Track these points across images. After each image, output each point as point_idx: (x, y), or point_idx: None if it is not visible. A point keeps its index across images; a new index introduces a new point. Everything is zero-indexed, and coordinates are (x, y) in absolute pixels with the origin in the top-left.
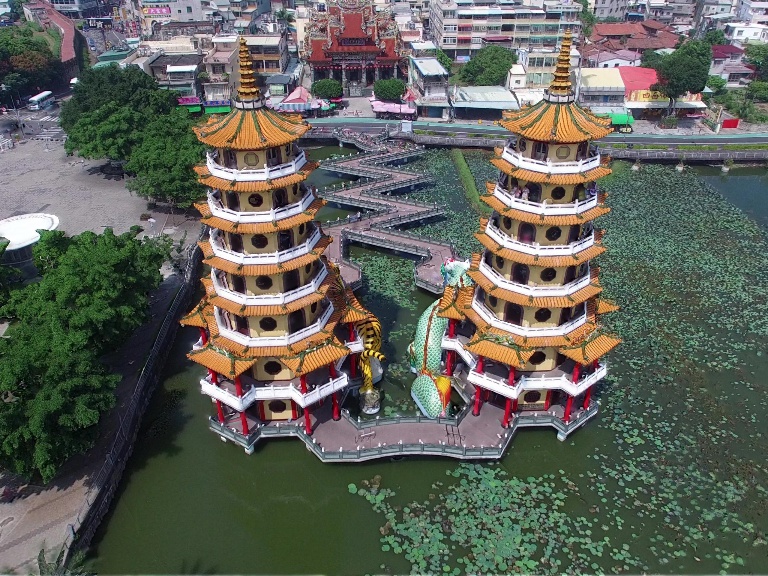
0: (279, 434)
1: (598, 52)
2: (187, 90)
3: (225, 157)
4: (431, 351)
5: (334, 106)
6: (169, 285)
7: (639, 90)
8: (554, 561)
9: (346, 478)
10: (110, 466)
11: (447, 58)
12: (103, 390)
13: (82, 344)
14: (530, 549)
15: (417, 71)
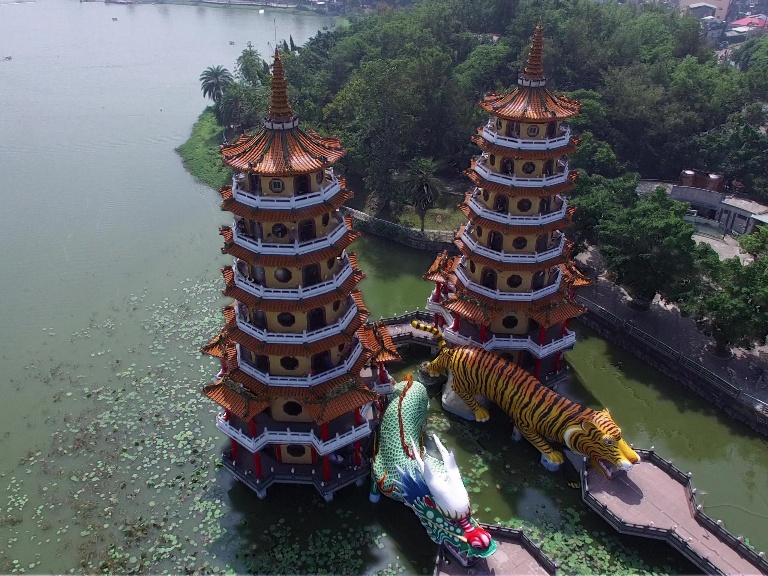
0: None
1: None
2: None
3: None
4: None
5: None
6: (764, 397)
7: None
8: None
9: None
10: None
11: None
12: None
13: None
14: None
15: None
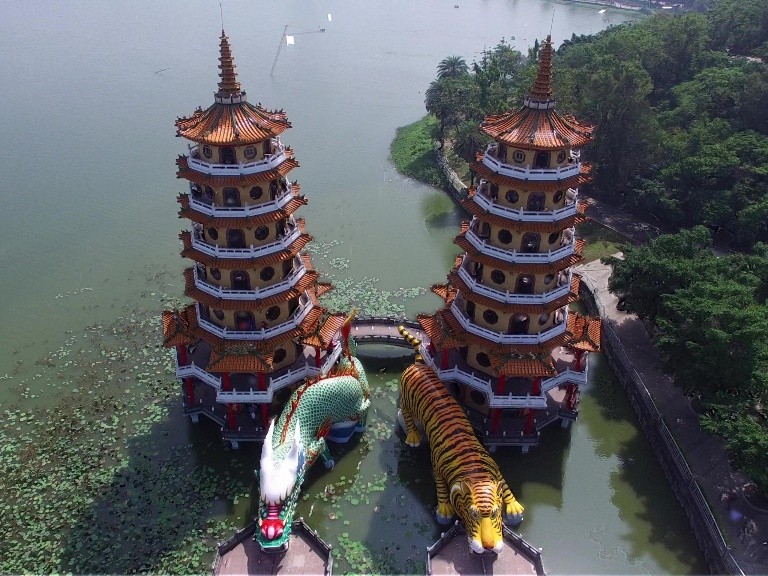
0: None
1: None
2: None
3: None
4: None
5: None
6: (765, 573)
7: None
8: None
9: None
10: None
11: None
12: None
13: None
14: None
15: None
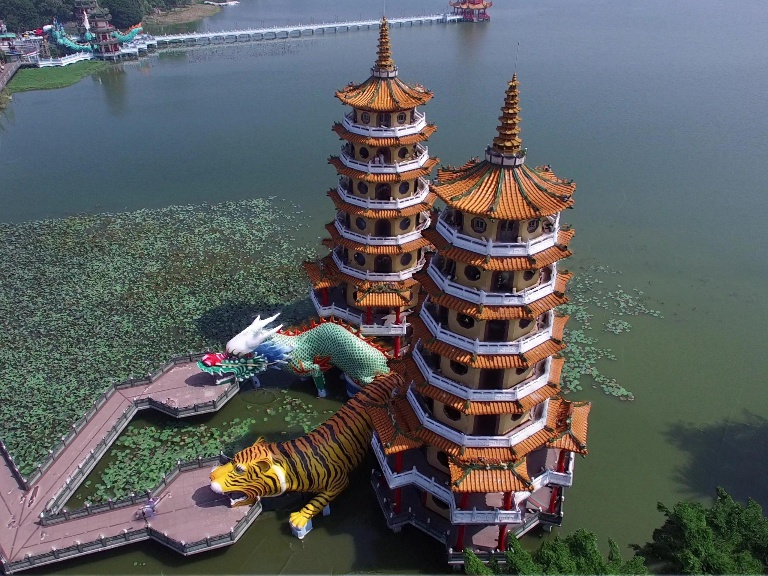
0: None
1: None
2: None
3: None
4: None
5: None
6: None
7: None
8: None
9: None
10: None
11: None
12: None
13: None
14: None
15: None
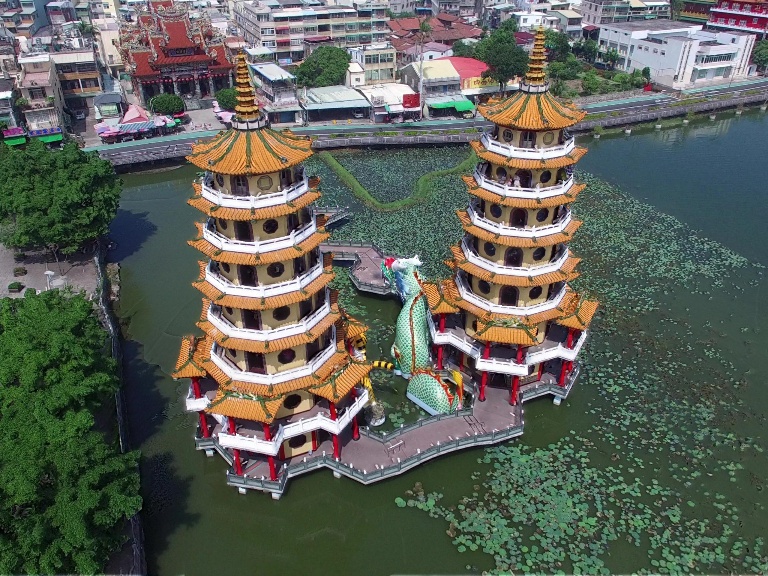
0: (306, 469)
1: (415, 46)
2: (4, 120)
3: (232, 184)
4: (419, 350)
5: (177, 121)
6: None
7: (470, 78)
8: (608, 512)
9: (387, 494)
10: (138, 557)
11: (275, 62)
12: (124, 472)
13: (88, 426)
14: (584, 508)
15: (258, 77)
